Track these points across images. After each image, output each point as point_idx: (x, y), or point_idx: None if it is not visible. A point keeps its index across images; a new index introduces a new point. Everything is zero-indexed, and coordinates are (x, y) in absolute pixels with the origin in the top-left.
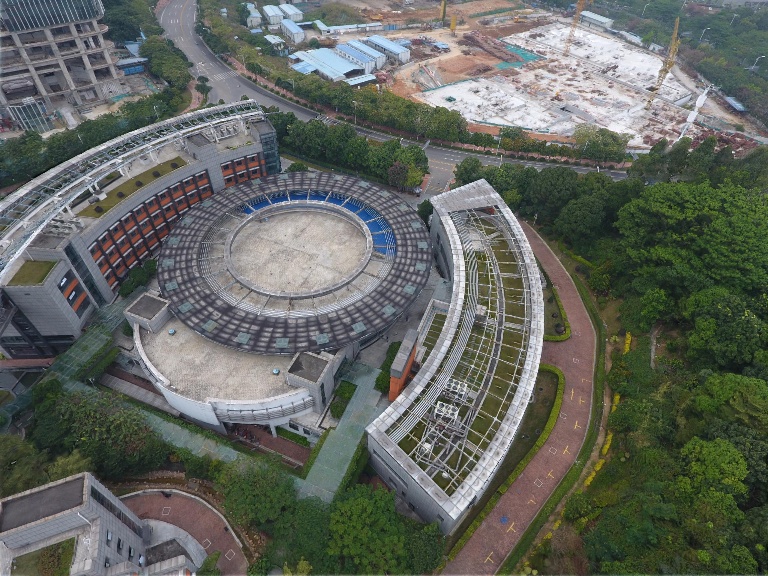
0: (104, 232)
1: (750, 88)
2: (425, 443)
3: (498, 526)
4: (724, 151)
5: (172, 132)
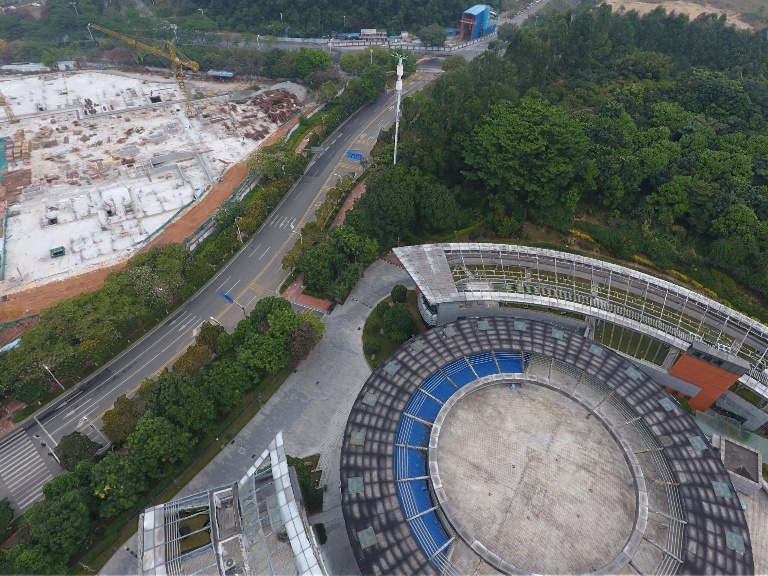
0: None
1: (212, 56)
2: (766, 373)
3: None
4: (455, 93)
5: None
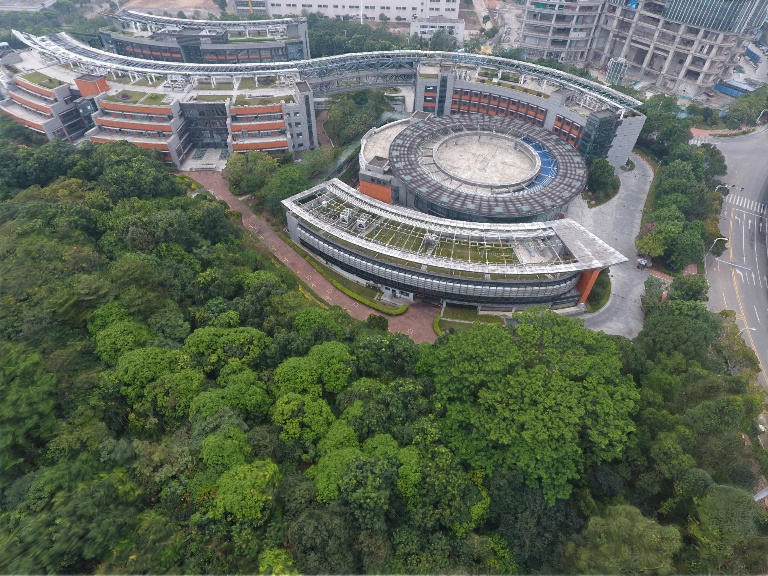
0: (469, 90)
1: None
2: None
3: (288, 254)
4: None
5: None
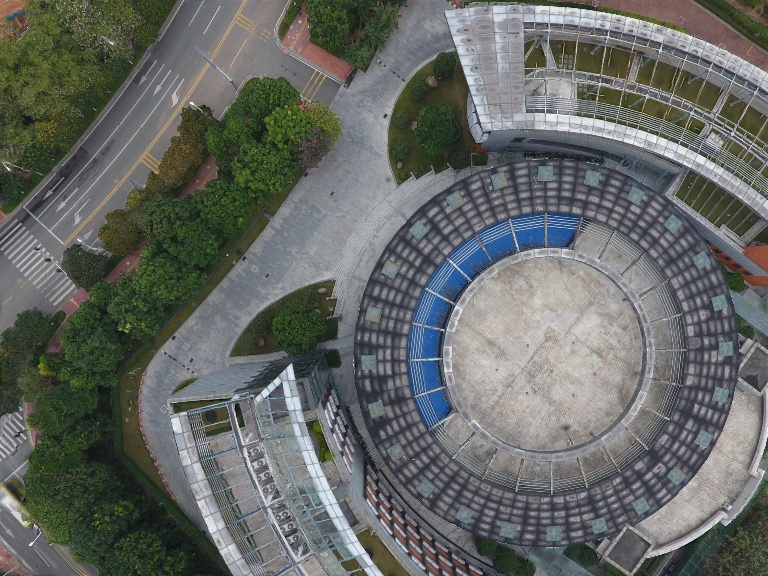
0: None
1: None
2: None
3: None
4: None
5: None
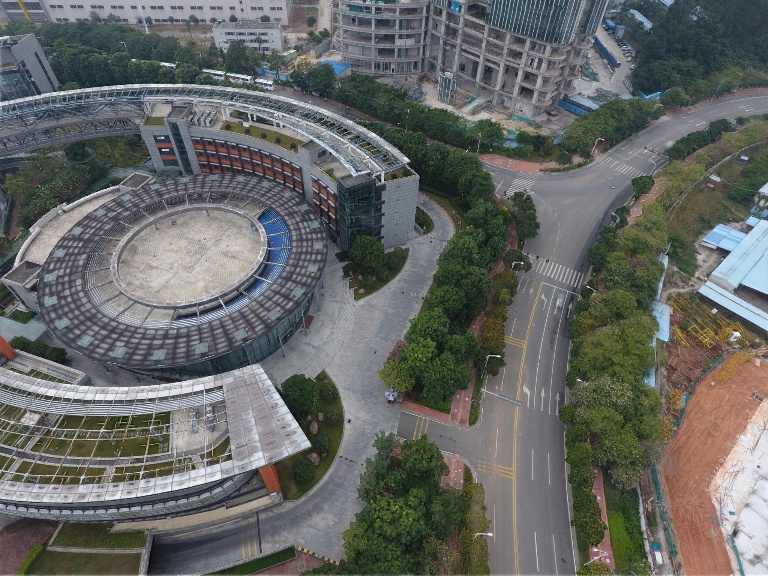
0: (211, 139)
1: None
2: None
3: None
4: None
5: (325, 127)
